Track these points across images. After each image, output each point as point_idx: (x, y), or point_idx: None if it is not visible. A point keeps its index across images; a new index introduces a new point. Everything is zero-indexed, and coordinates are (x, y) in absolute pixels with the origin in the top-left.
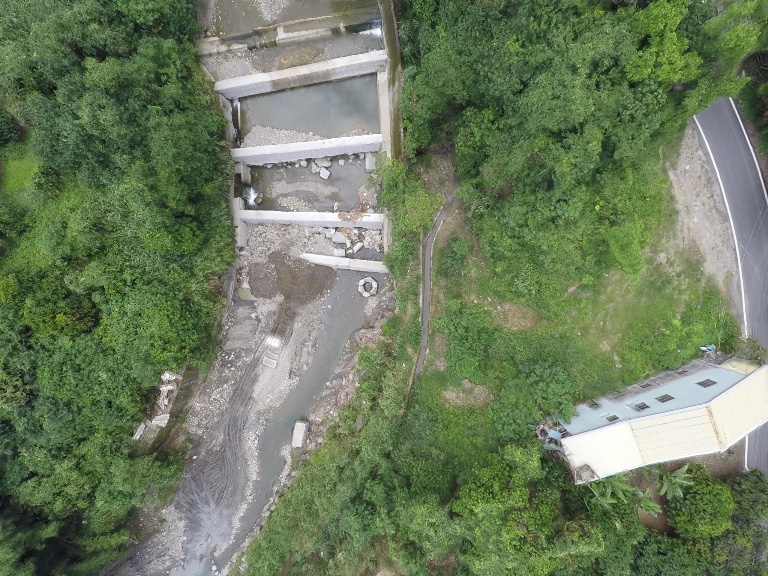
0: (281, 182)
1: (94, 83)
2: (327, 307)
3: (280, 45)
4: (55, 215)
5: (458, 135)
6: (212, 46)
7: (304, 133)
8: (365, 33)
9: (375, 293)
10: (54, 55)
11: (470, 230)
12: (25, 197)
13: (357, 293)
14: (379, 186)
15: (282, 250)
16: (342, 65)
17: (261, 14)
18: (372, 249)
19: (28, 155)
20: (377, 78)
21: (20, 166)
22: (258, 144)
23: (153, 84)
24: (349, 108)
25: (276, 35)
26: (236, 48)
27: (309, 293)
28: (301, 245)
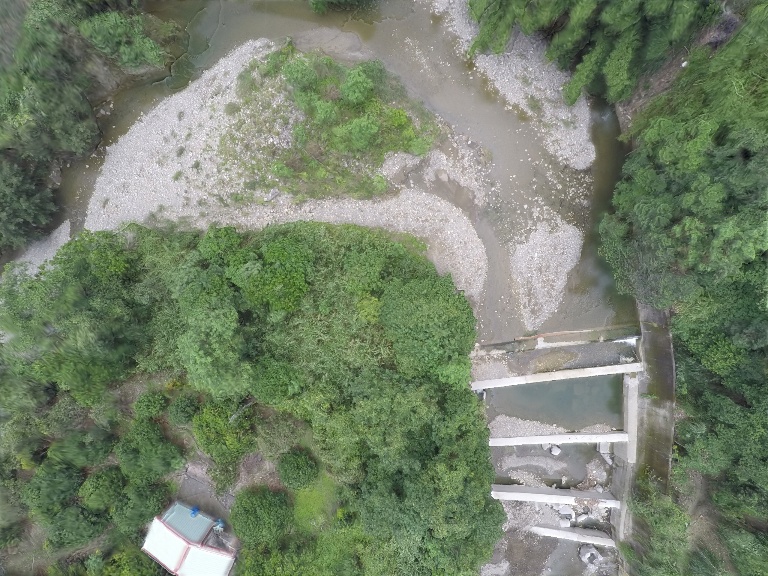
0: (512, 456)
1: (451, 497)
2: (546, 569)
3: (536, 349)
4: (343, 544)
5: (750, 498)
6: (472, 351)
7: (548, 424)
8: (619, 341)
9: (597, 562)
10: (408, 462)
11: (727, 550)
12: (314, 526)
13: (577, 558)
14: (609, 465)
15: (516, 528)
16: (598, 374)
17: (524, 325)
18: (594, 518)
19: (317, 485)
20: (625, 380)
21: (310, 496)
22: (504, 435)
23: (460, 442)
24: (590, 400)
25: (536, 344)
26: (495, 353)
27: (537, 565)
28: (533, 521)
